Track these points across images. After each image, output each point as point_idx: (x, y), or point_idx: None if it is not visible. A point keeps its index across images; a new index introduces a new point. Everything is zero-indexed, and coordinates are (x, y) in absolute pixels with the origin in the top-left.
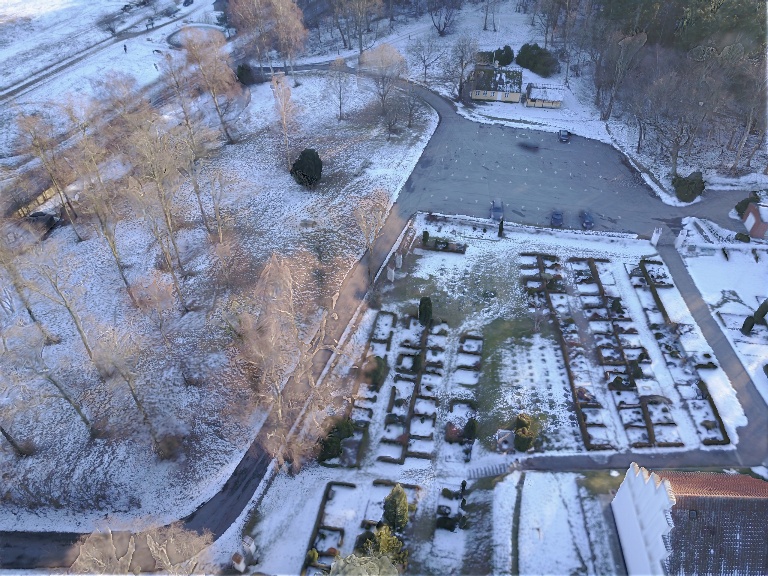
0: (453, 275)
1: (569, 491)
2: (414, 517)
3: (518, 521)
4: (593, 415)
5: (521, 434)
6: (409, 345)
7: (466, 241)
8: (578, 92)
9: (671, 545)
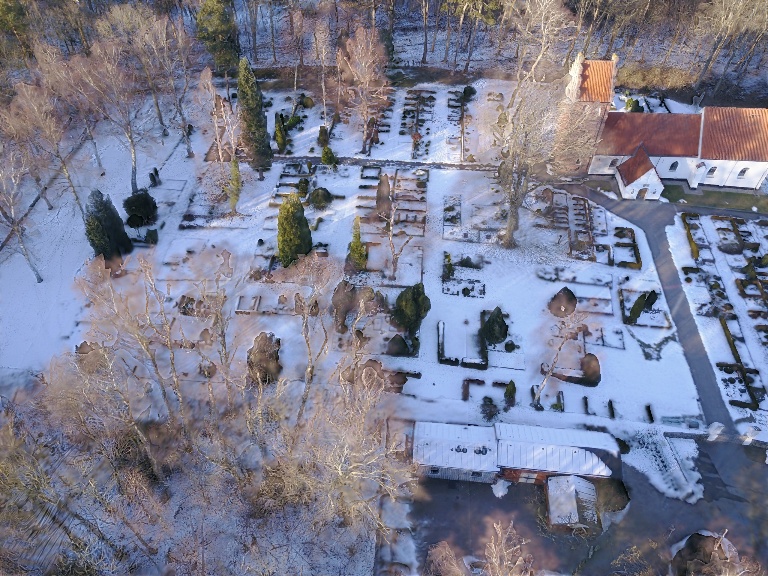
0: None
1: None
2: None
3: None
4: None
5: None
6: None
7: None
8: None
9: None
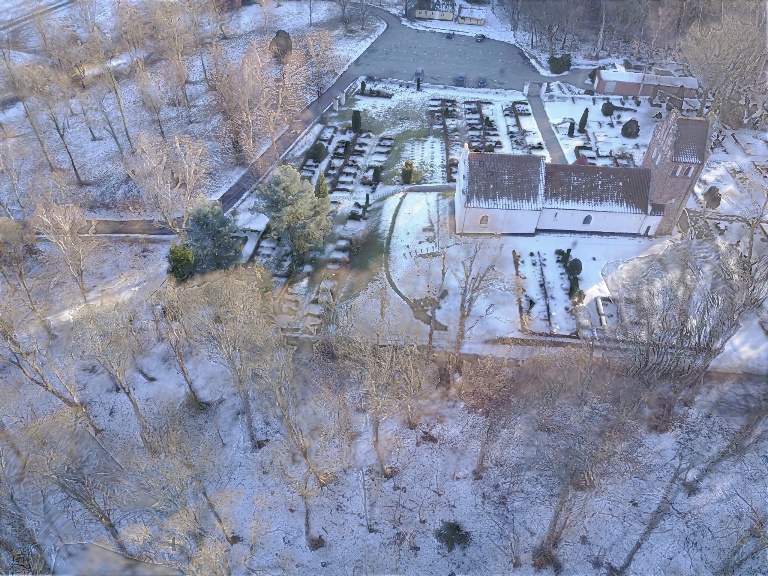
0: (380, 109)
1: (432, 199)
2: (335, 215)
3: (398, 211)
4: (457, 169)
5: (405, 168)
6: (344, 142)
7: (393, 92)
8: (500, 15)
9: (469, 182)
